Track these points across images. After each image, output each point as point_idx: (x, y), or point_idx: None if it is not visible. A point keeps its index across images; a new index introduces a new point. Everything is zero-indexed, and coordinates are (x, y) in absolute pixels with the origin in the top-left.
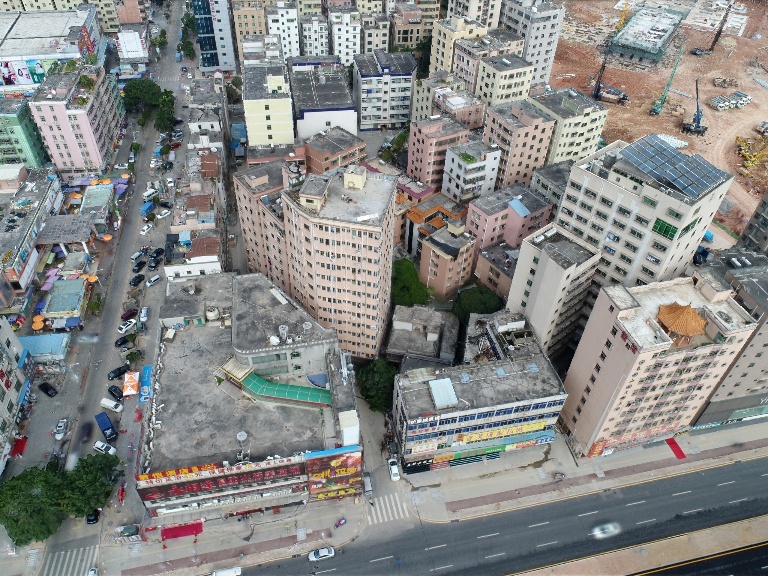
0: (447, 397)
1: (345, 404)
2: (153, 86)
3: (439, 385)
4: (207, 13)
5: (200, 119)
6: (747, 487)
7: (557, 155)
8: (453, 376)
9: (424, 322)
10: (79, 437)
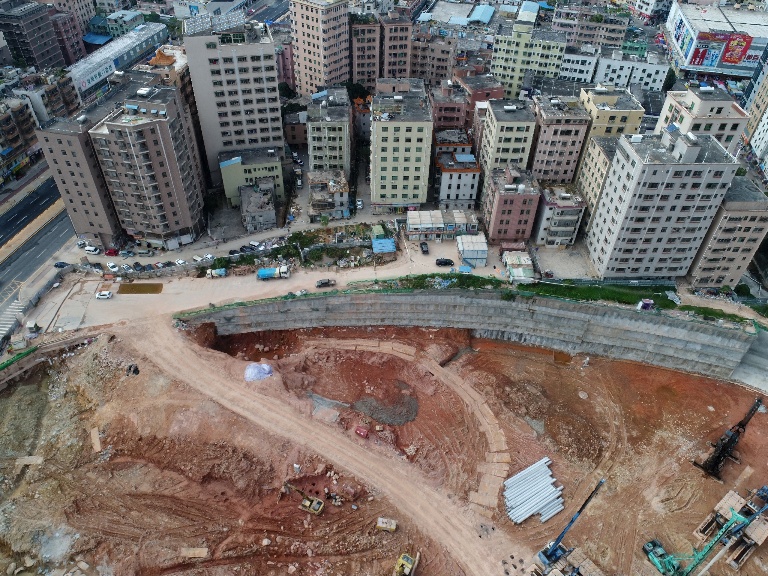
0: None
1: None
2: None
3: None
4: (765, 61)
5: None
6: None
7: None
8: None
9: (298, 100)
10: None
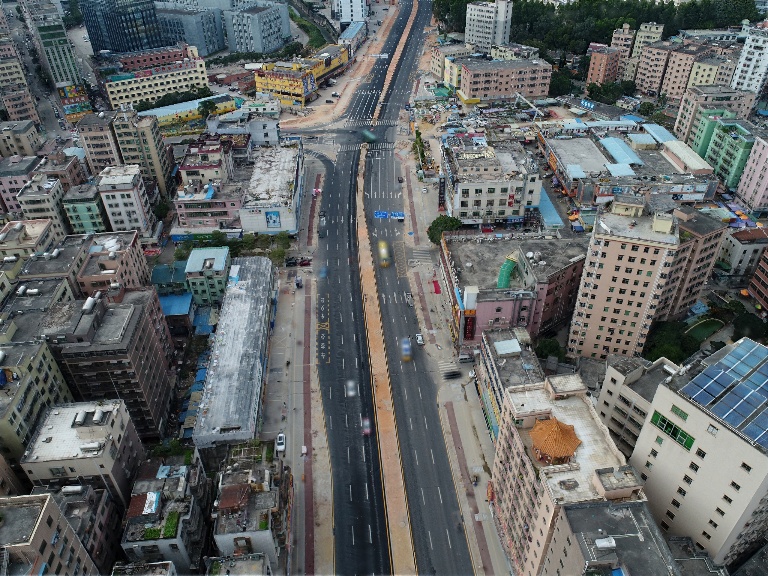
0: (503, 348)
1: (490, 297)
2: None
3: (514, 344)
4: None
5: None
6: None
7: None
8: (530, 361)
9: None
10: None
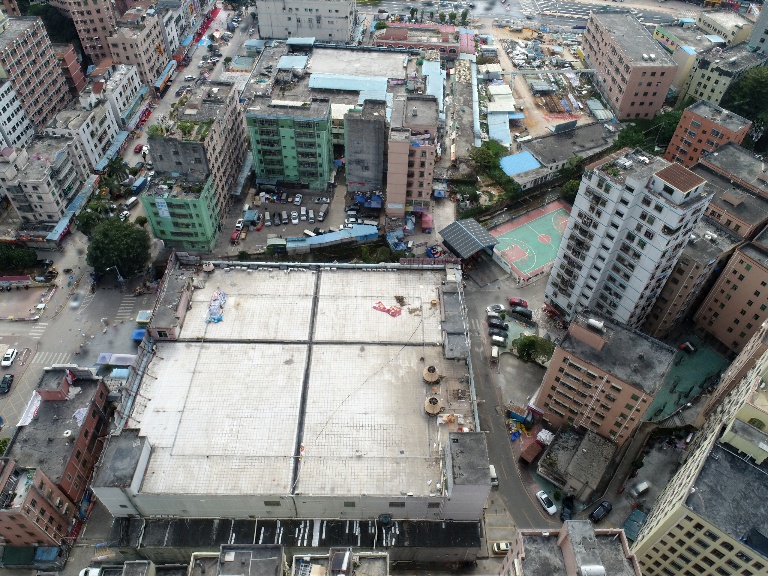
0: None
1: None
2: None
3: None
4: None
5: (78, 115)
6: None
7: None
8: None
9: None
10: (245, 31)
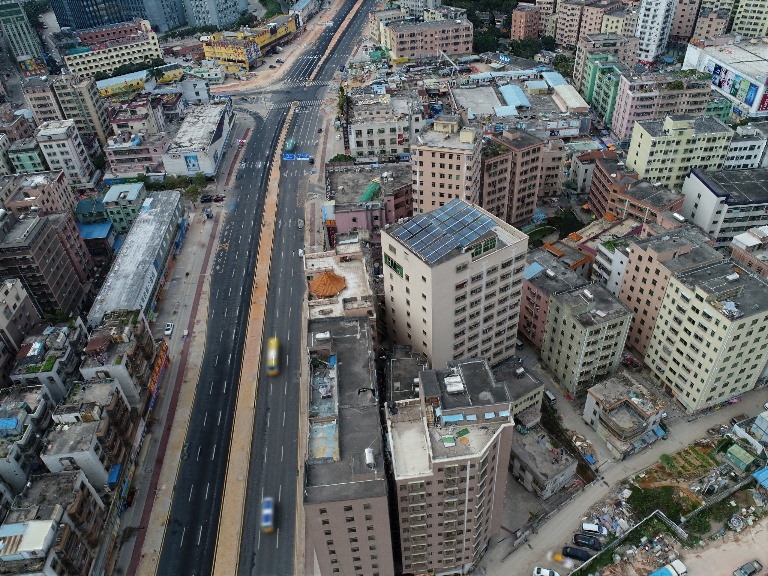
0: None
1: None
2: None
3: None
4: None
5: None
6: (274, 467)
7: (662, 317)
8: (366, 254)
9: None
10: None
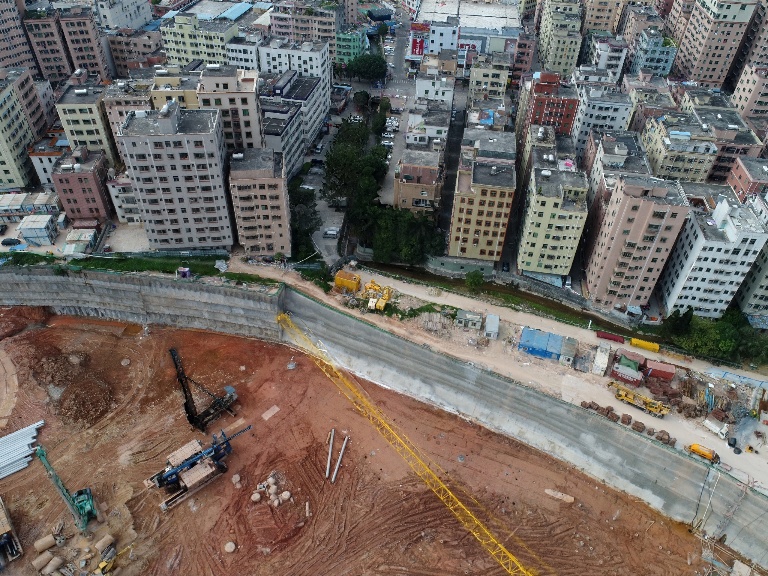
0: None
1: None
2: (368, 63)
3: None
4: None
5: None
6: None
7: None
8: None
9: None
10: None
